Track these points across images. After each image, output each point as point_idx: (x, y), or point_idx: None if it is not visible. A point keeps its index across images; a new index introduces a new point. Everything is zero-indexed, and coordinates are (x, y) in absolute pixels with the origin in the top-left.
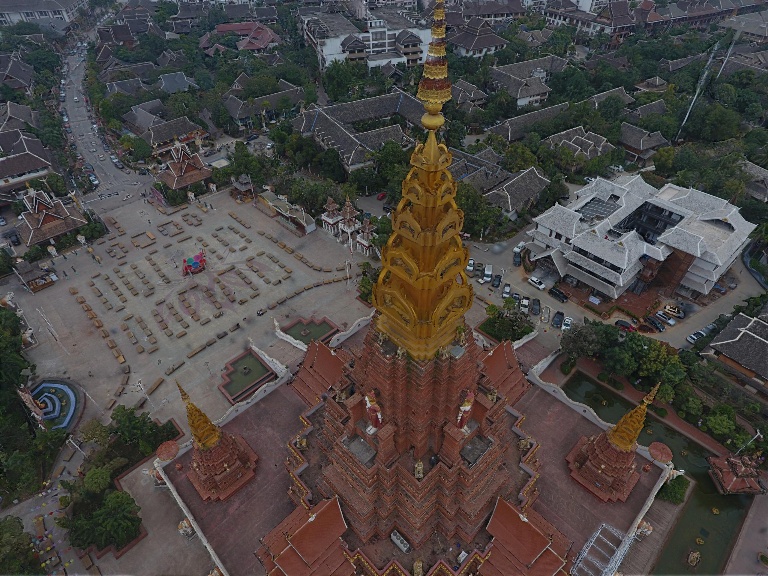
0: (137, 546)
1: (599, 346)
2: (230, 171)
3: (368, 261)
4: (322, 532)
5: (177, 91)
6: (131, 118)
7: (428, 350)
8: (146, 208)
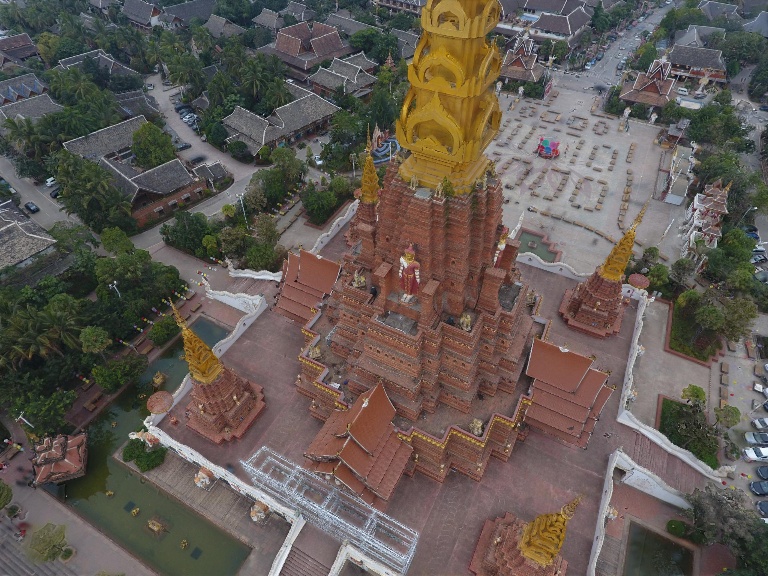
0: (314, 229)
1: (738, 552)
2: (686, 113)
3: (675, 261)
4: (319, 275)
5: (756, 31)
6: (680, 35)
7: (408, 171)
8: (587, 101)
